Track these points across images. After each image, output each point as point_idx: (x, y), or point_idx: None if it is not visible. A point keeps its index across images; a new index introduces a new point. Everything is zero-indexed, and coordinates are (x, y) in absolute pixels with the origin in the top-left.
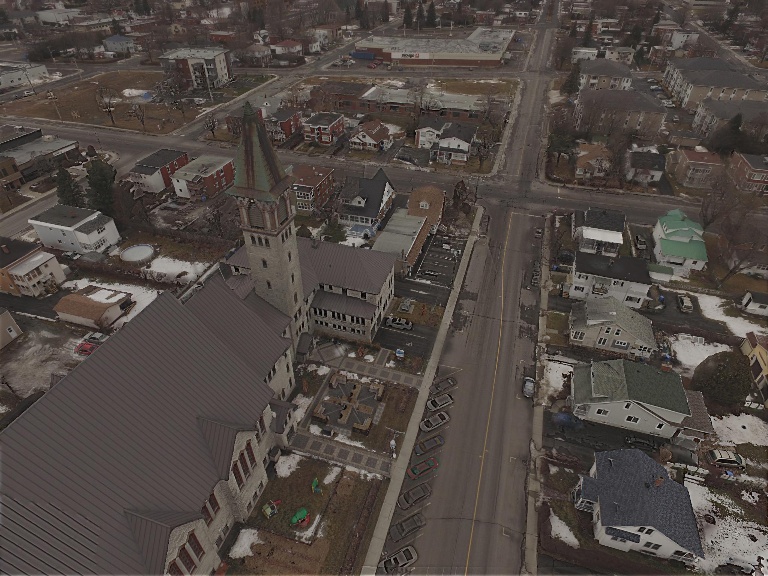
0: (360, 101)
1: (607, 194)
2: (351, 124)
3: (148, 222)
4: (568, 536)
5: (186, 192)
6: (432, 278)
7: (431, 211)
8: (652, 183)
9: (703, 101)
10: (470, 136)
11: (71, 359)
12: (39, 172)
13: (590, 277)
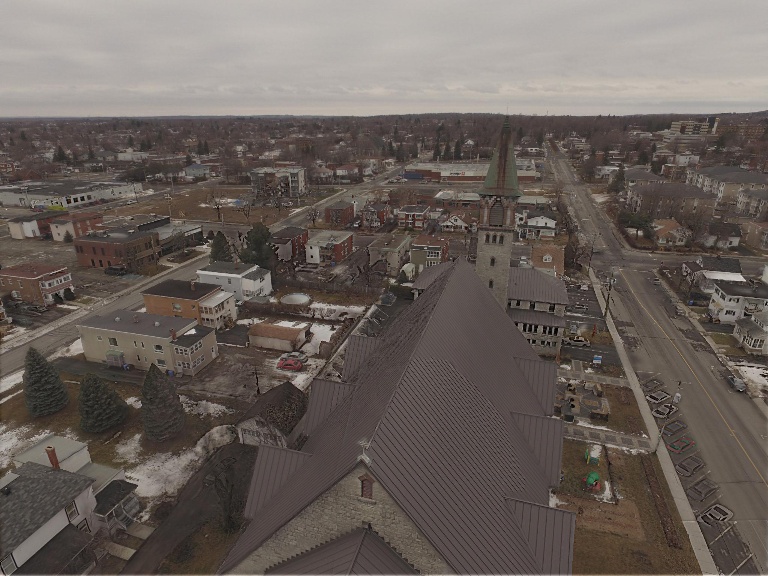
0: (436, 199)
1: (696, 256)
2: (433, 216)
3: (294, 278)
4: None
5: (317, 258)
6: (582, 311)
7: (555, 264)
8: (732, 248)
9: (743, 191)
10: (554, 216)
11: (276, 373)
12: (173, 248)
13: (741, 299)
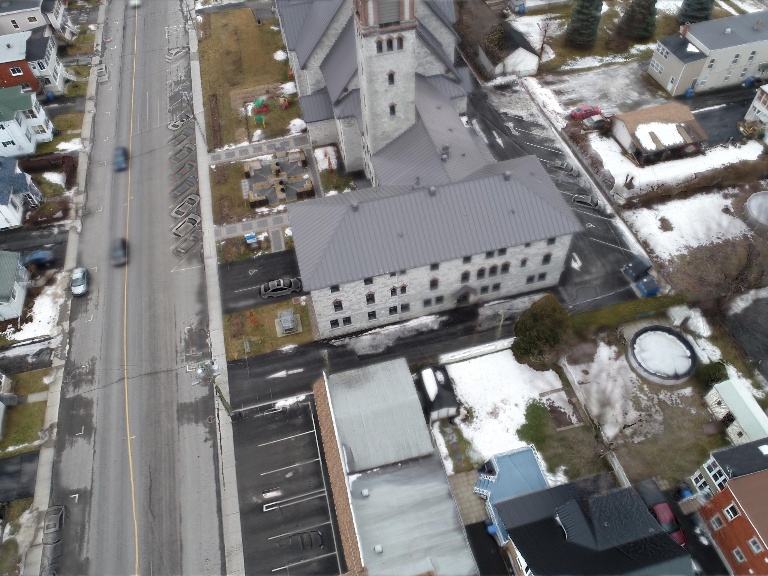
0: None
1: None
2: None
3: None
4: (51, 176)
5: None
6: None
7: None
8: None
9: None
10: None
11: (586, 104)
12: None
13: None
